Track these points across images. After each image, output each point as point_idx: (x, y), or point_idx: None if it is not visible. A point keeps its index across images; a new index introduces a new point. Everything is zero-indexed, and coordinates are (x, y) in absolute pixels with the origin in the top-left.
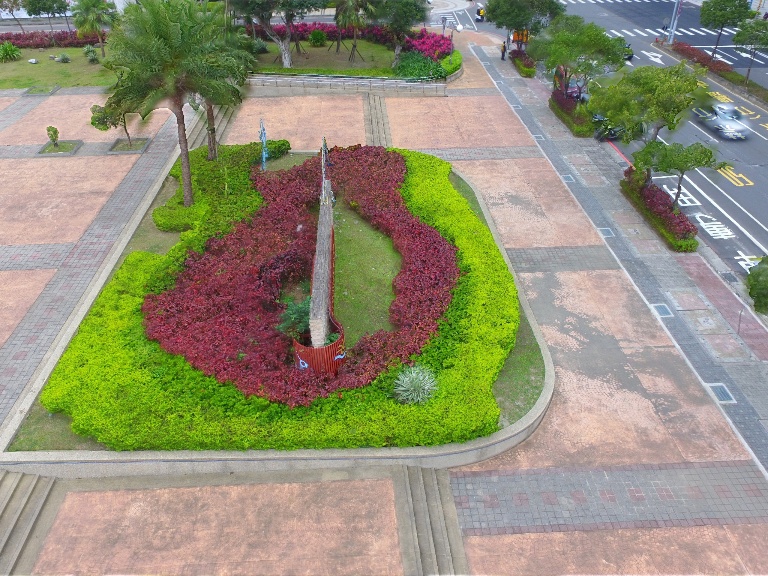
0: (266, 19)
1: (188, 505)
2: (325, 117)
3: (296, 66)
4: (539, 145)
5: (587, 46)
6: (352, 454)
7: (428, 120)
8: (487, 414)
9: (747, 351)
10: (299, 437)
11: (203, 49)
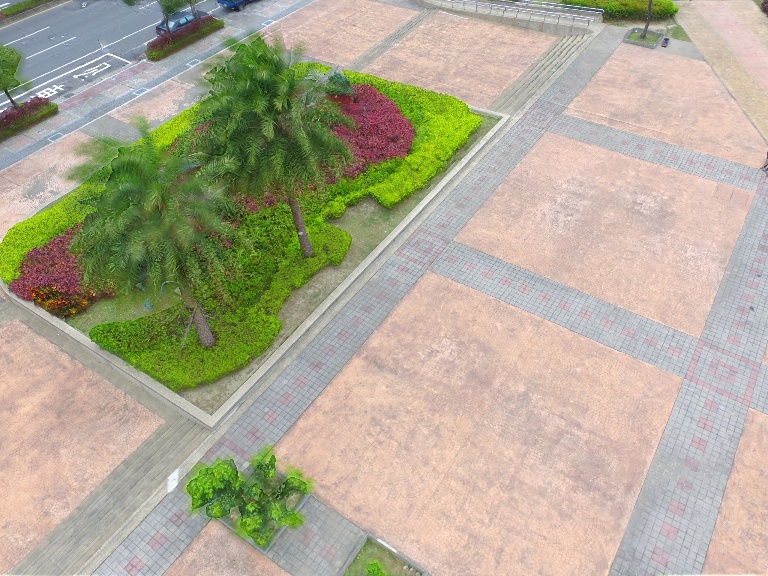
0: None
1: None
2: None
3: None
4: None
5: None
6: None
7: None
8: None
9: (151, 68)
10: None
11: None
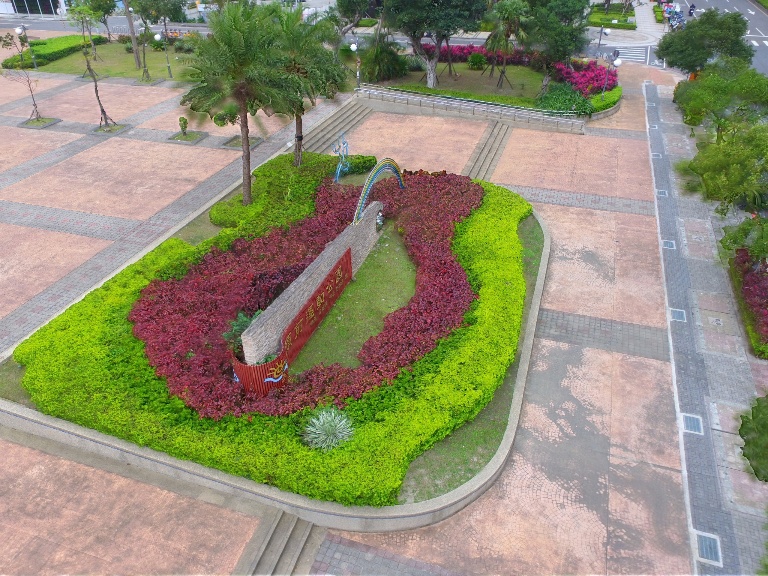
0: (418, 38)
1: (75, 482)
2: (438, 140)
3: (441, 86)
4: (657, 201)
5: (736, 95)
6: (232, 481)
7: (545, 157)
8: (382, 483)
9: None
10: (187, 448)
11: (269, 59)
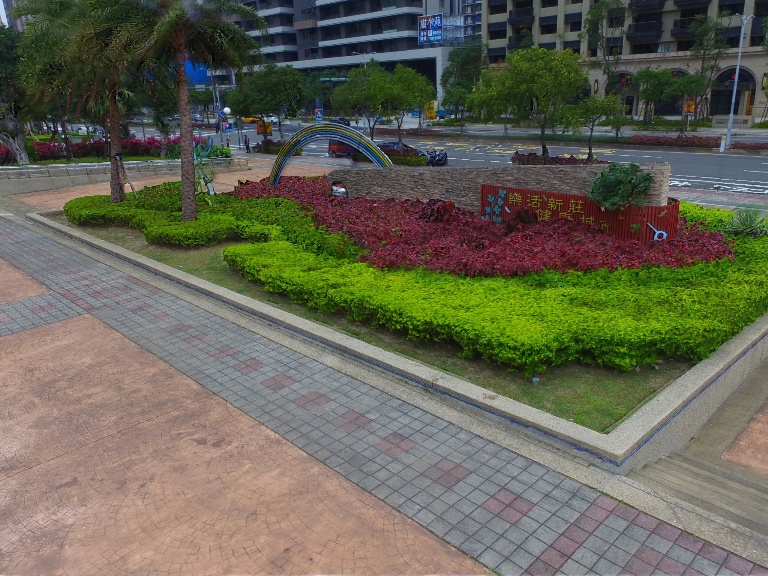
0: None
1: None
2: None
3: None
4: None
5: (406, 82)
6: None
7: None
8: None
9: (767, 200)
10: None
11: None
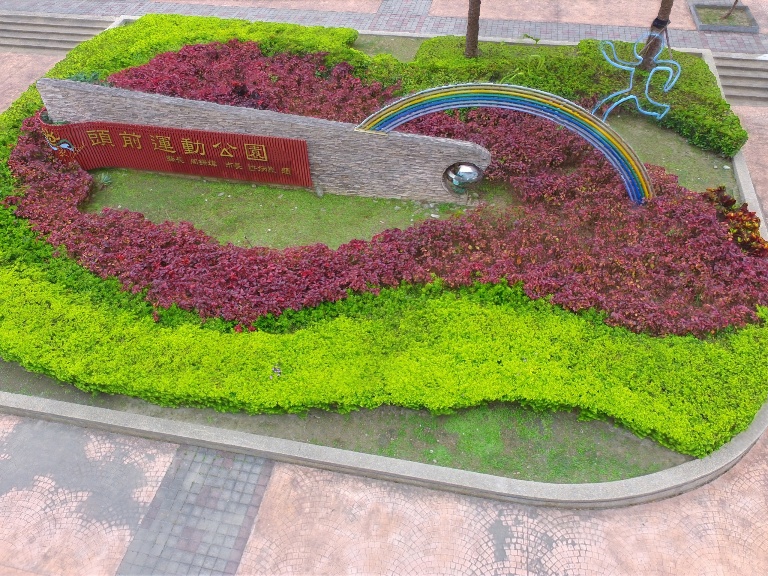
0: None
1: None
2: None
3: None
4: None
5: None
6: None
7: None
8: None
9: None
10: None
11: None
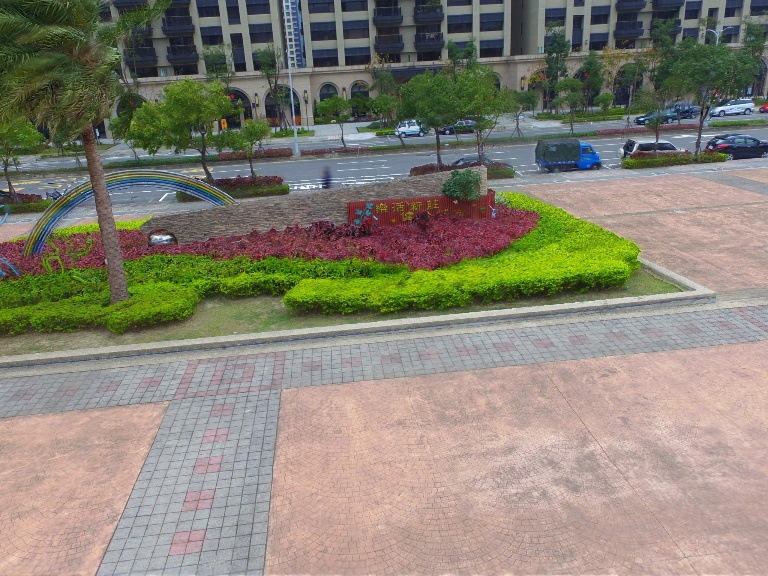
0: None
1: None
2: None
3: None
4: None
5: None
6: None
7: None
8: None
9: None
10: None
11: None
